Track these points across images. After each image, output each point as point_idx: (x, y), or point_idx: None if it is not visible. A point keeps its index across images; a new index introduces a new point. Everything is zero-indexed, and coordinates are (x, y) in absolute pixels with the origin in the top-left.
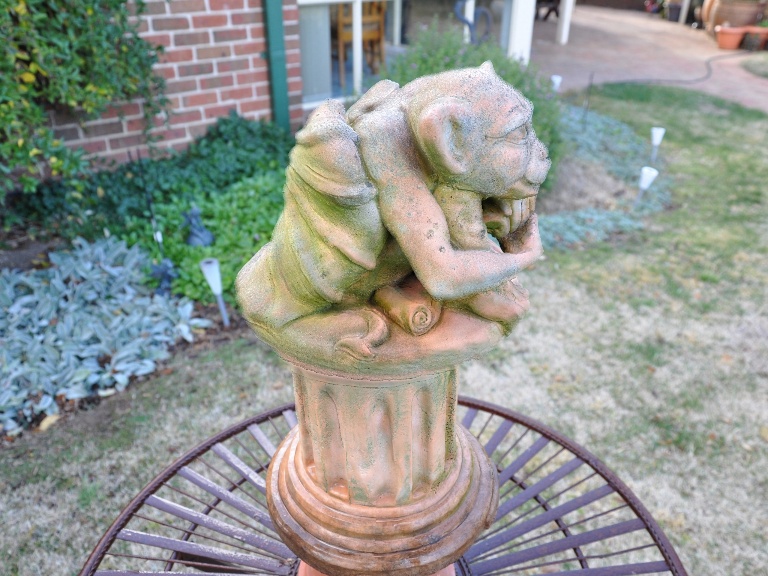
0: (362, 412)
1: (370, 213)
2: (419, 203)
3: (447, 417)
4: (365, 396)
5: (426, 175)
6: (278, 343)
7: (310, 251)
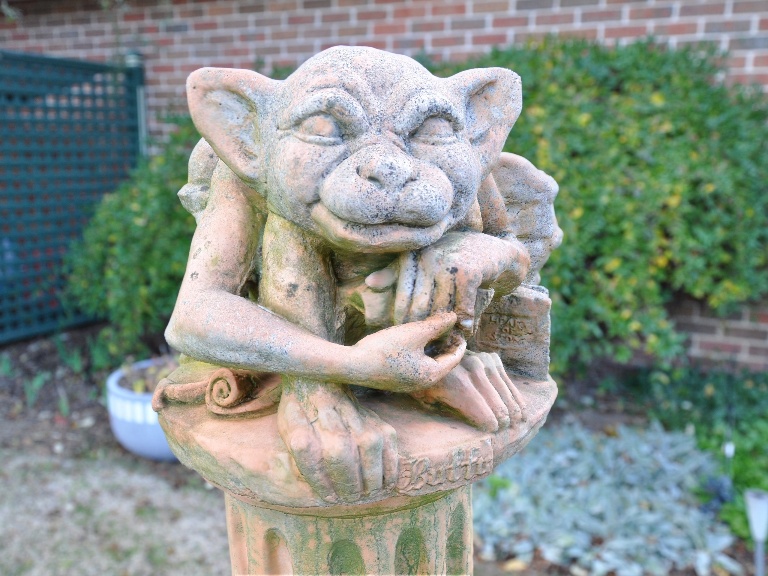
0: None
1: None
2: (215, 214)
3: None
4: None
5: None
6: None
7: None
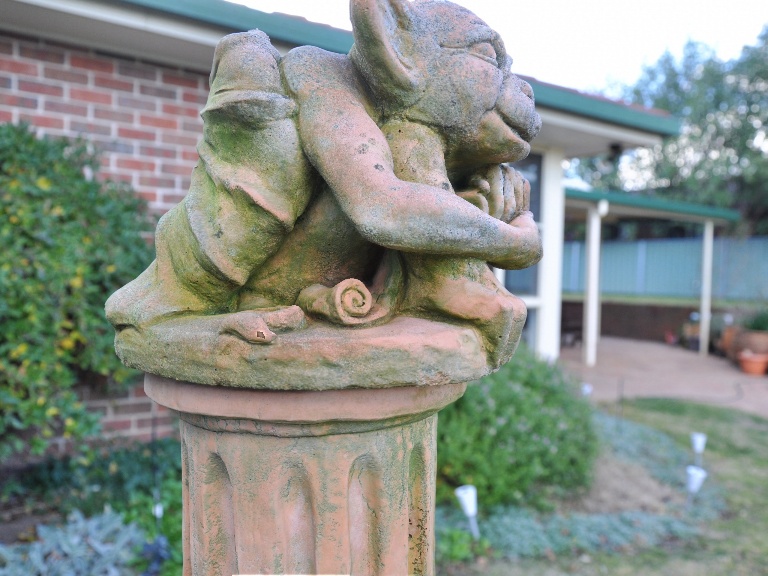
0: (267, 487)
1: (285, 133)
2: (351, 117)
3: (415, 548)
4: (273, 455)
5: (366, 103)
6: (145, 341)
7: (208, 208)
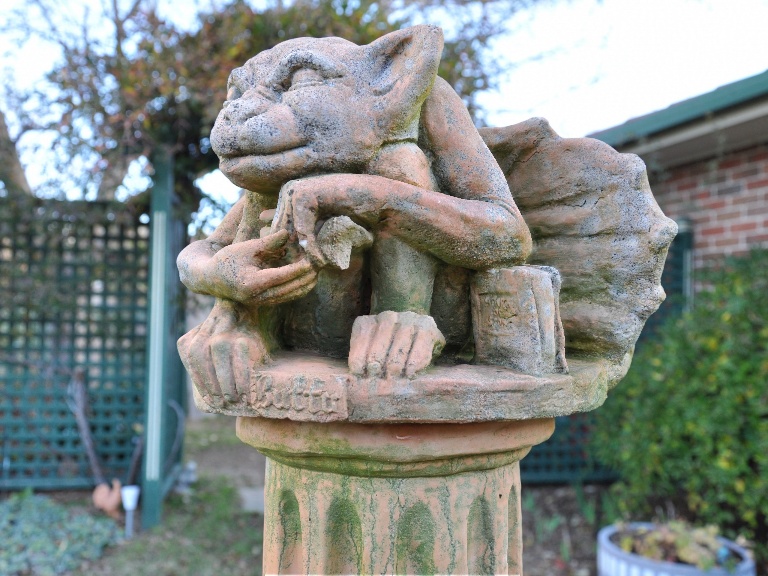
0: None
1: None
2: None
3: None
4: None
5: None
6: None
7: None
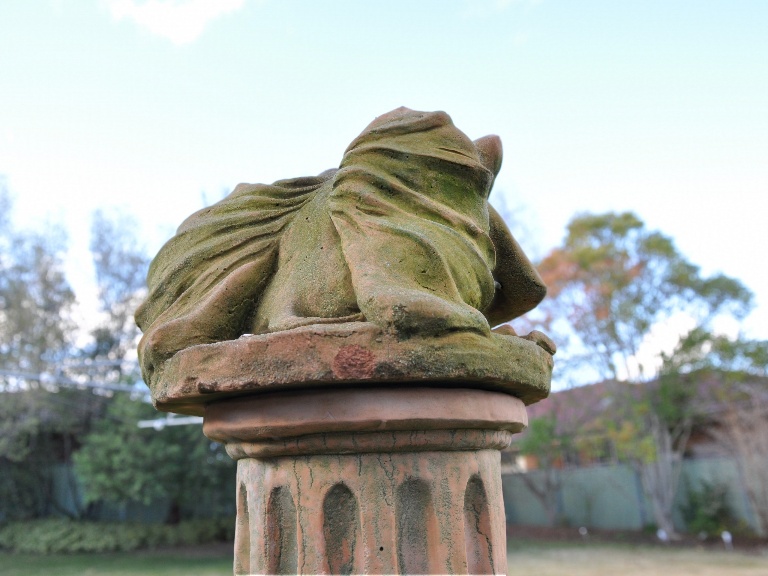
0: None
1: None
2: None
3: None
4: None
5: None
6: (497, 345)
7: None
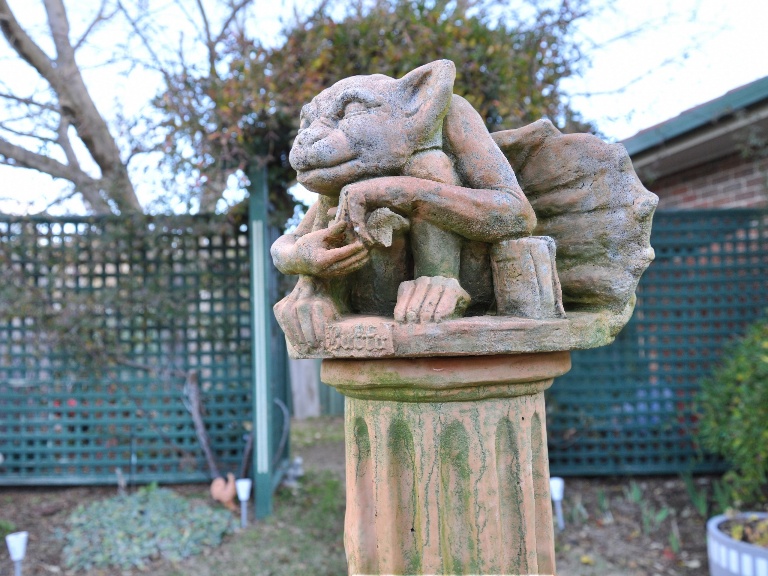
0: None
1: None
2: None
3: None
4: None
5: None
6: None
7: None
